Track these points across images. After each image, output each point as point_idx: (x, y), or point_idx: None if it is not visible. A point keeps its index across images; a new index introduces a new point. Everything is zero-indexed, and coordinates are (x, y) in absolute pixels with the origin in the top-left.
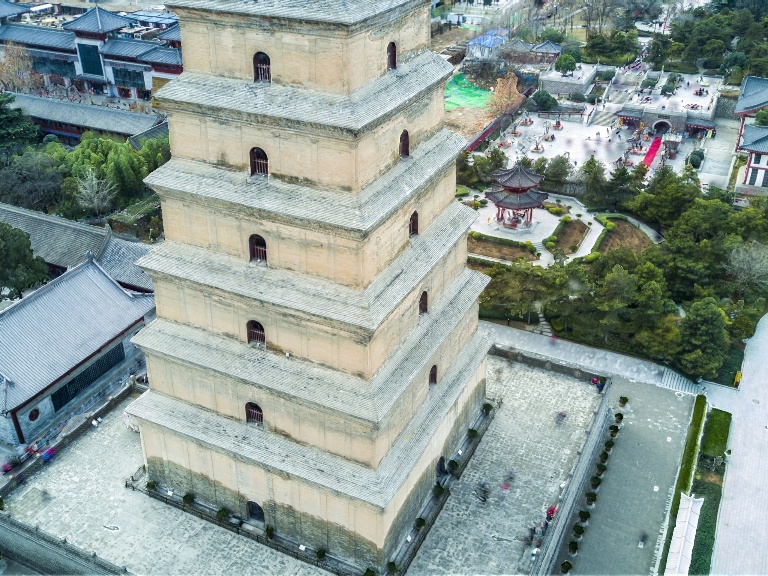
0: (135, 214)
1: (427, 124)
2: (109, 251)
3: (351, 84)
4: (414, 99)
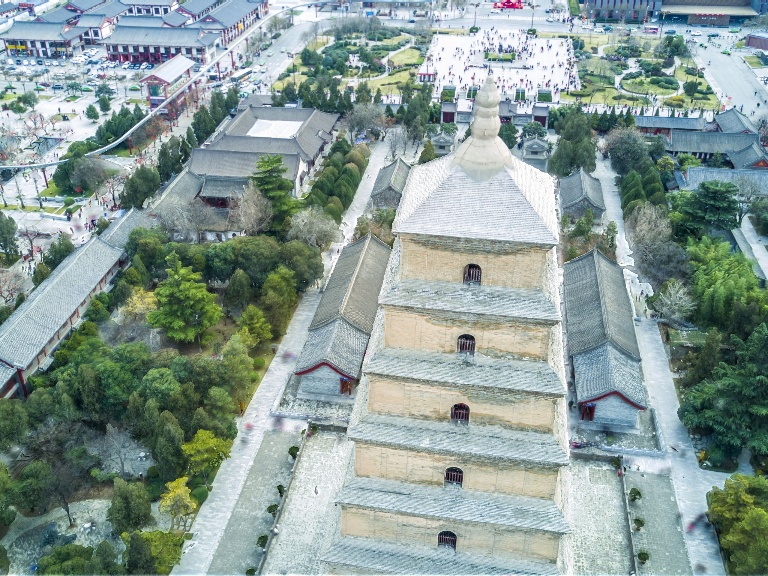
0: (688, 340)
1: (511, 417)
2: (597, 351)
3: (393, 342)
4: (480, 388)
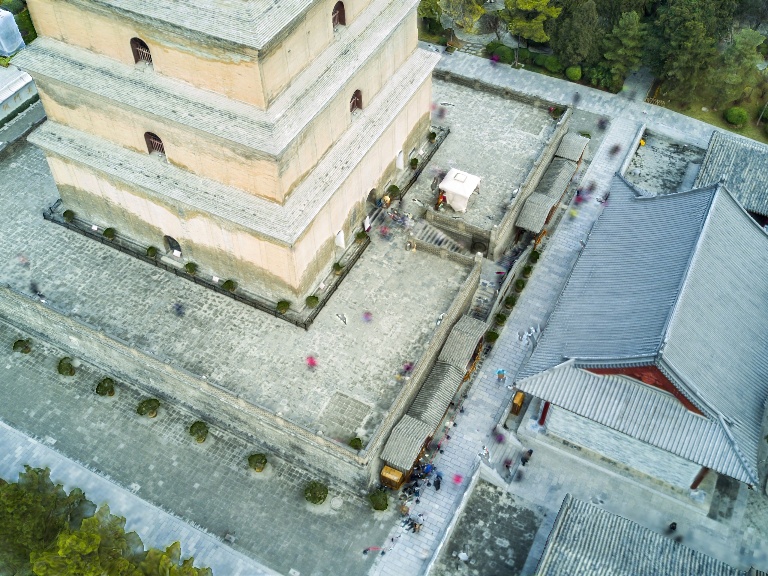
0: None
1: None
2: None
3: None
4: None
